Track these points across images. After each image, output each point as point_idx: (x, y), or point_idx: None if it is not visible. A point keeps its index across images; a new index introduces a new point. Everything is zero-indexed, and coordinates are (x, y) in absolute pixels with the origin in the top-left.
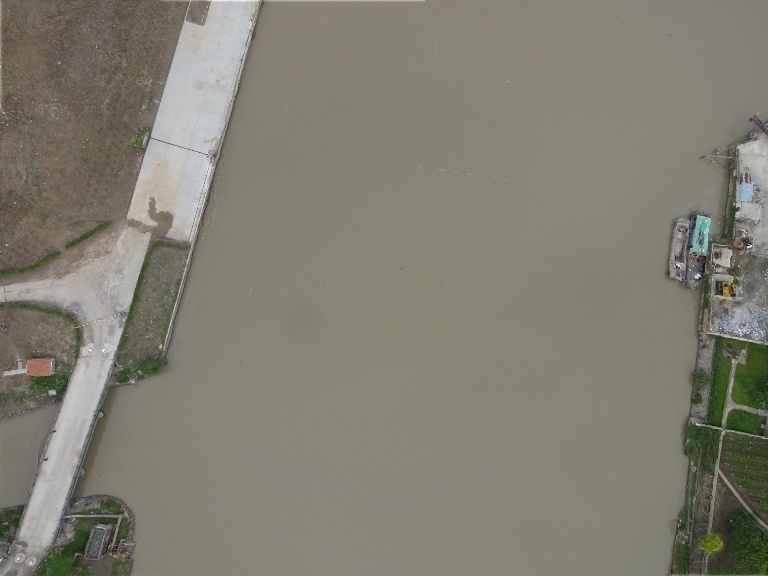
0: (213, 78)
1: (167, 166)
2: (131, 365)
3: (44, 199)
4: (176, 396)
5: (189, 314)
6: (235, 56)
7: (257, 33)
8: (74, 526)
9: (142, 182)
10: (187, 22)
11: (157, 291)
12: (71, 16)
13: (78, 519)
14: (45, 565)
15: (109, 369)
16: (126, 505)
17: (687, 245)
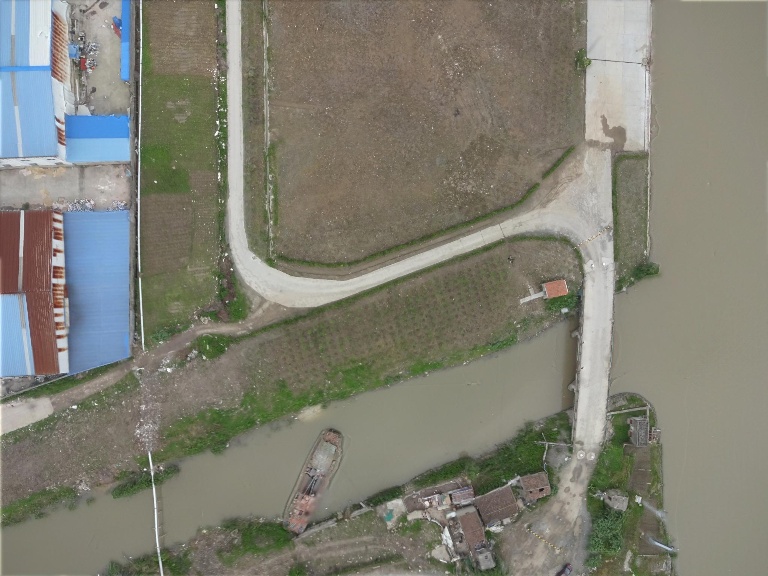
0: None
1: (608, 83)
2: (625, 274)
3: (511, 137)
4: (666, 295)
5: (658, 218)
6: None
7: None
8: (612, 422)
9: (590, 103)
10: None
11: (630, 202)
12: None
13: (613, 416)
14: (603, 458)
15: (613, 280)
16: (644, 398)
17: None
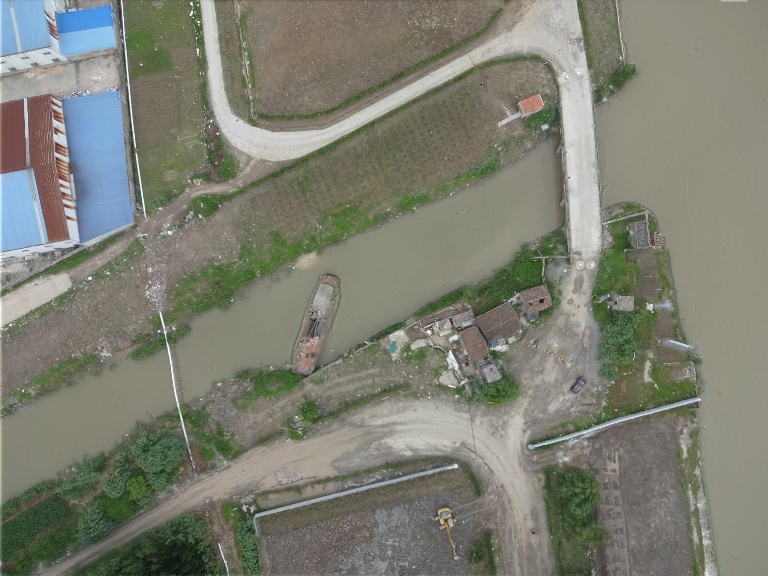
0: None
1: None
2: (602, 82)
3: None
4: (649, 98)
5: (630, 25)
6: None
7: None
8: (609, 231)
9: None
10: None
11: (598, 11)
12: None
13: (610, 225)
14: (604, 265)
15: (589, 87)
16: (642, 206)
17: None
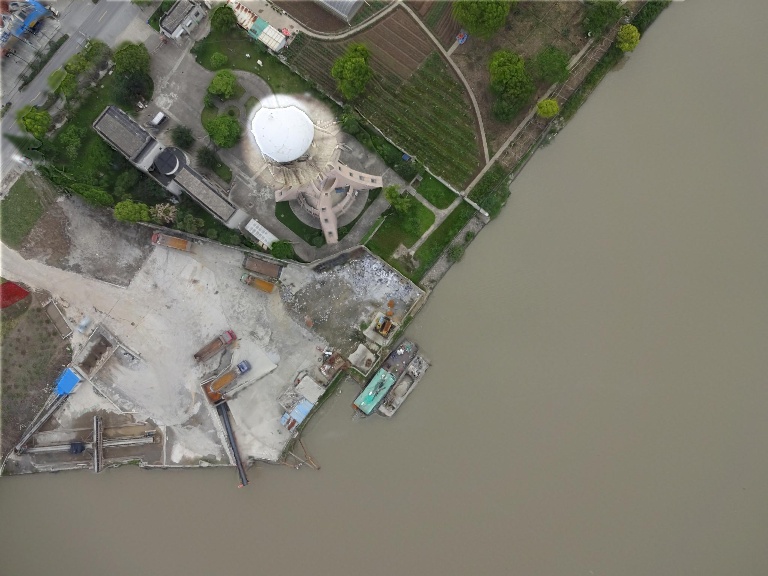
0: None
1: None
2: None
3: None
4: None
5: None
6: None
7: None
8: None
9: None
10: None
11: None
12: None
13: None
14: None
15: None
16: None
17: (392, 389)
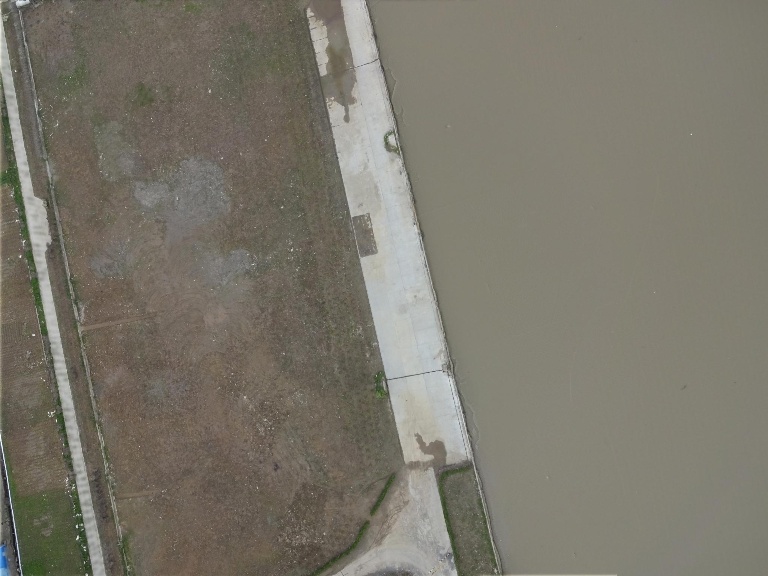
0: (410, 296)
1: (414, 398)
2: None
3: (332, 479)
4: None
5: (503, 527)
6: (418, 265)
7: (424, 231)
8: None
9: (401, 424)
10: (362, 258)
11: (466, 520)
12: (272, 308)
13: None
14: None
15: None
16: None
17: None
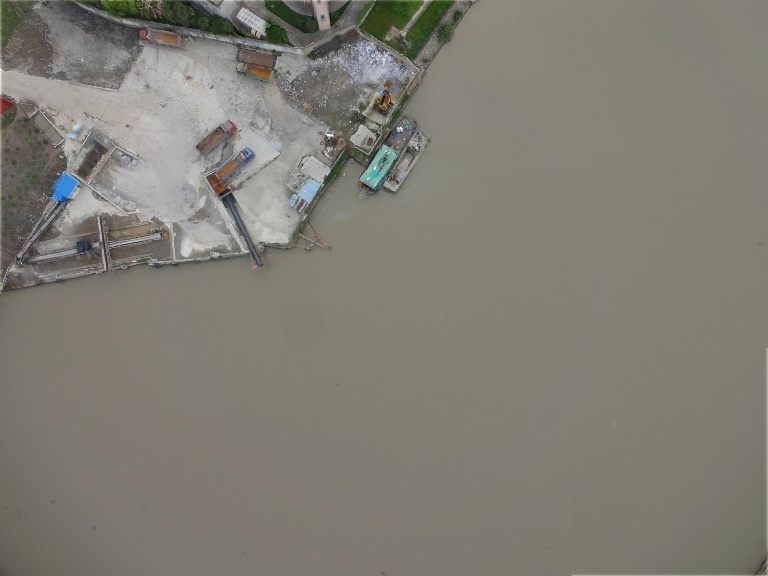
0: None
1: None
2: None
3: None
4: None
5: None
6: None
7: (764, 555)
8: None
9: None
10: None
11: None
12: None
13: None
14: None
15: None
16: None
17: (395, 165)
